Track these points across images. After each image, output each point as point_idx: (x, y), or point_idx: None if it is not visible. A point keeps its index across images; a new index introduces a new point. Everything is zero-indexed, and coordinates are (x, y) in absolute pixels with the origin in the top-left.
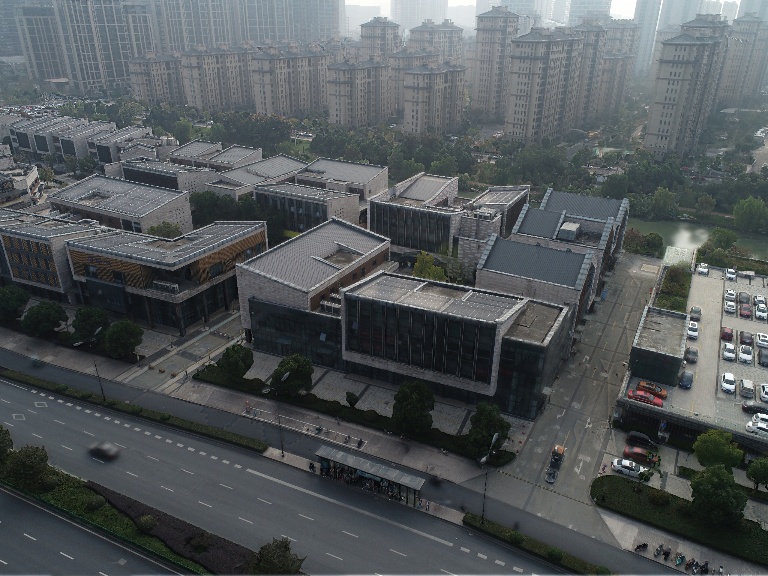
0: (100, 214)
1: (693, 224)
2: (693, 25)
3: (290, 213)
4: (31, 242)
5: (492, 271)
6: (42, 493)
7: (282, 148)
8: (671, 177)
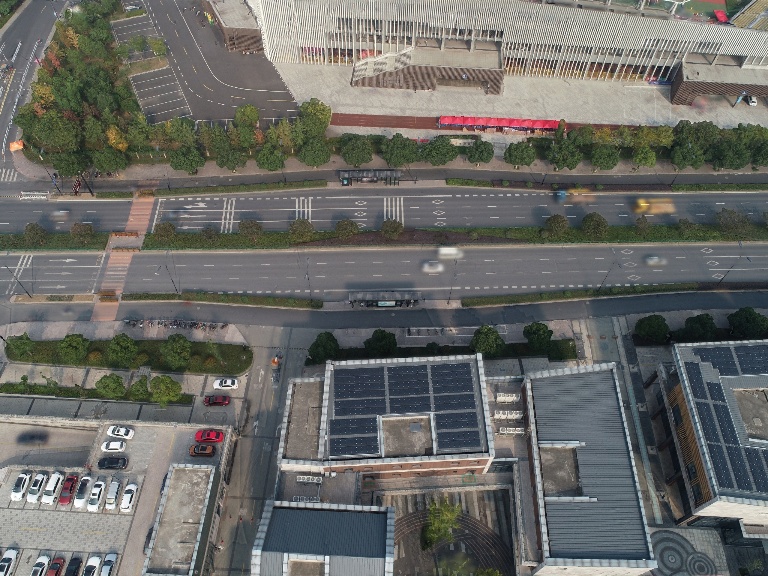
0: None
1: None
2: None
3: None
4: None
5: (374, 506)
6: (541, 230)
7: None
8: None
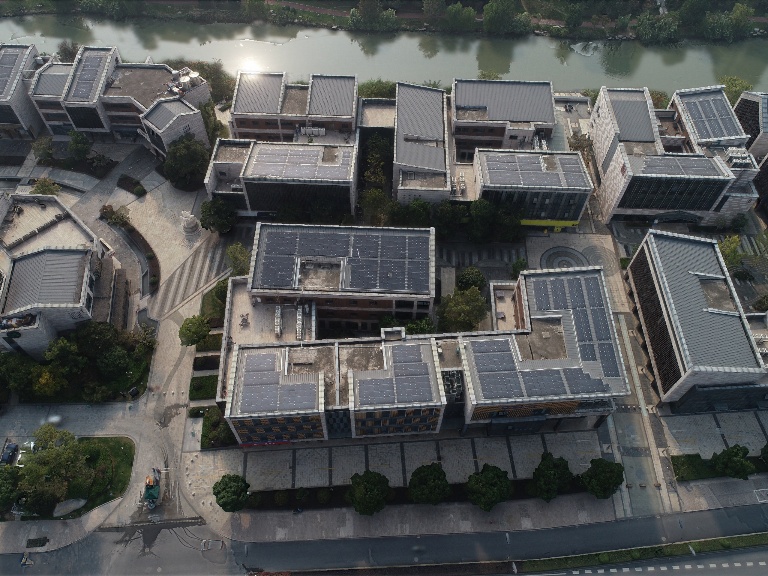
0: (355, 299)
1: (767, 40)
2: None
3: (530, 204)
4: (406, 411)
5: None
6: None
7: (257, 5)
8: None
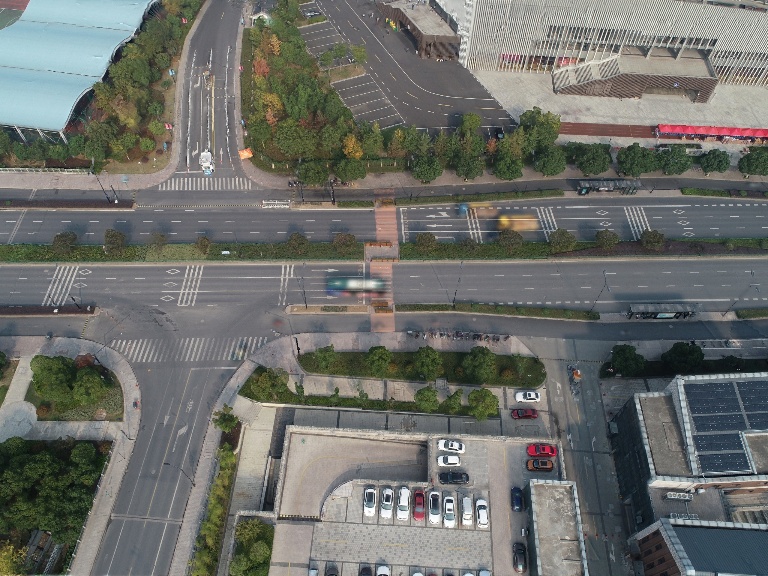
0: None
1: None
2: None
3: None
4: None
5: None
6: None
7: None
8: None
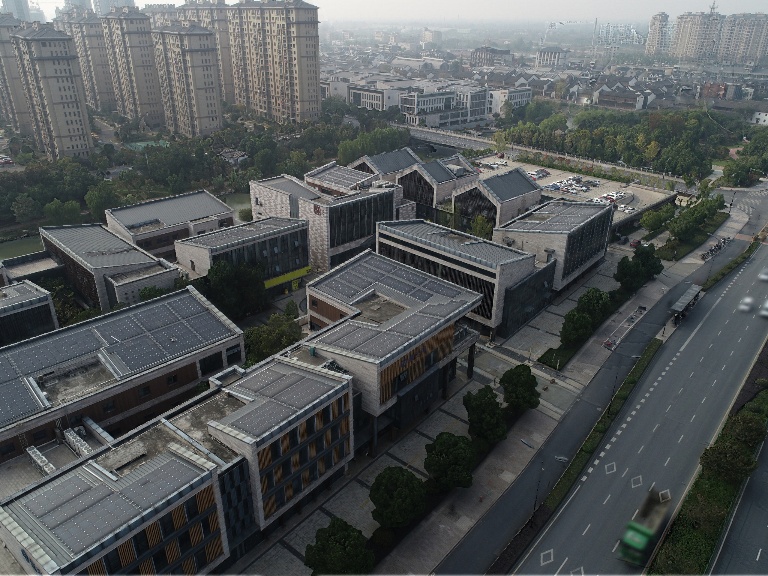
0: (146, 383)
1: None
2: (136, 17)
3: (261, 260)
4: (315, 416)
5: (508, 201)
6: None
7: None
8: (272, 145)
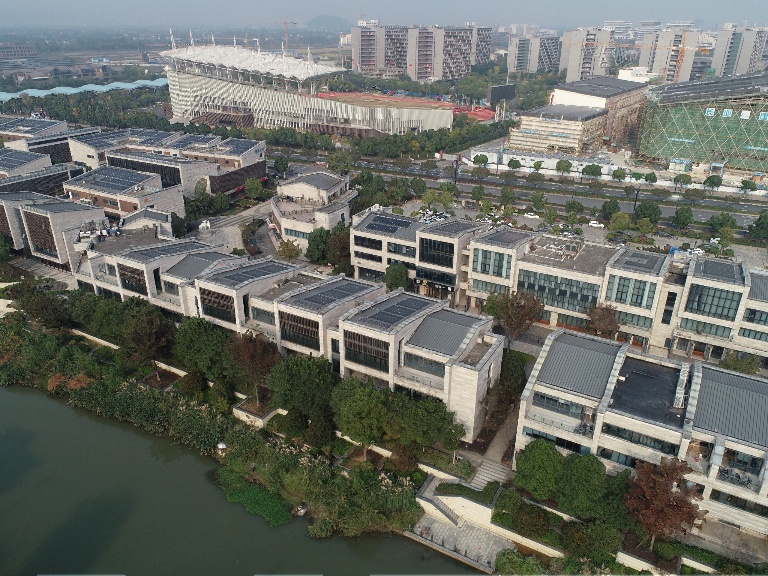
0: None
1: None
2: None
3: None
4: None
5: None
6: None
7: None
8: None
